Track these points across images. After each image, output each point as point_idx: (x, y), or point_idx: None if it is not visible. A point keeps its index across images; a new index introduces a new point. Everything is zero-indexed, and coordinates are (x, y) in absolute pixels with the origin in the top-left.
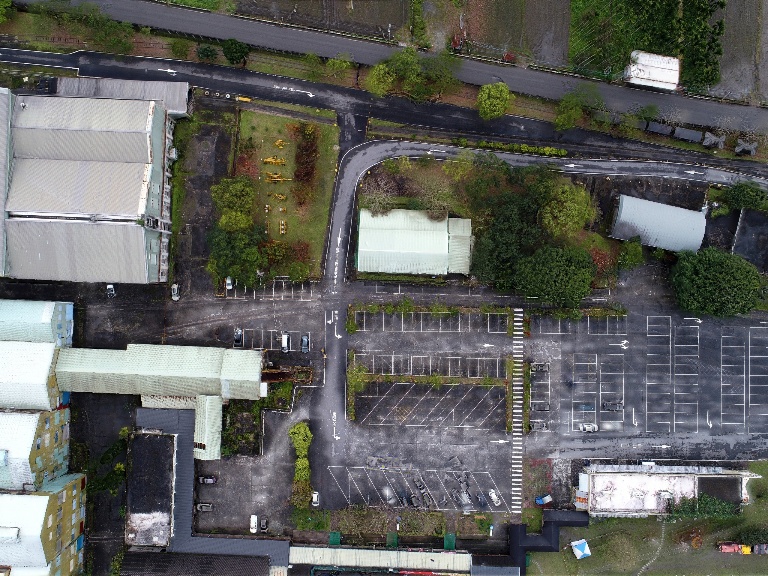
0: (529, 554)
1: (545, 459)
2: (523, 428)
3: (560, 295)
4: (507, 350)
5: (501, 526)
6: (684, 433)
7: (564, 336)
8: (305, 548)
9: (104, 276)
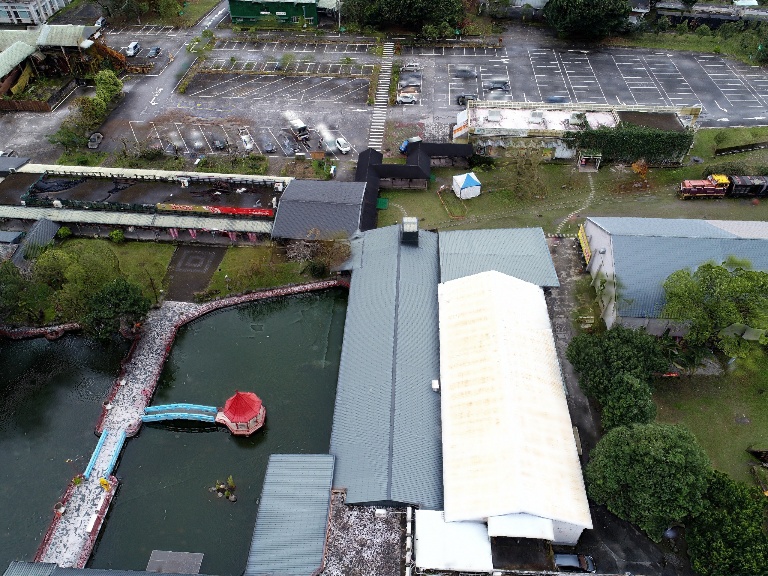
0: (388, 198)
1: (415, 123)
2: (388, 102)
3: (425, 3)
4: (375, 61)
5: (349, 172)
6: None
7: (438, 56)
8: (49, 165)
9: None
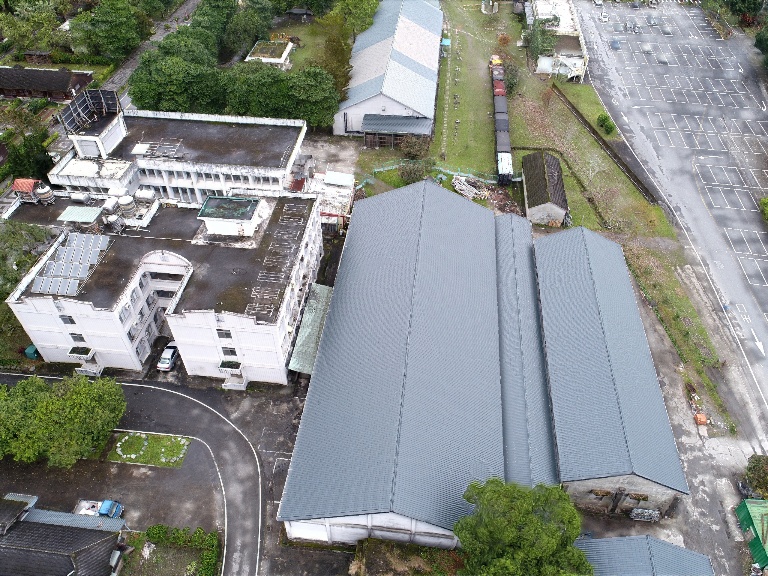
0: None
1: None
2: None
3: None
4: None
5: None
6: (613, 56)
7: (687, 16)
8: None
9: None
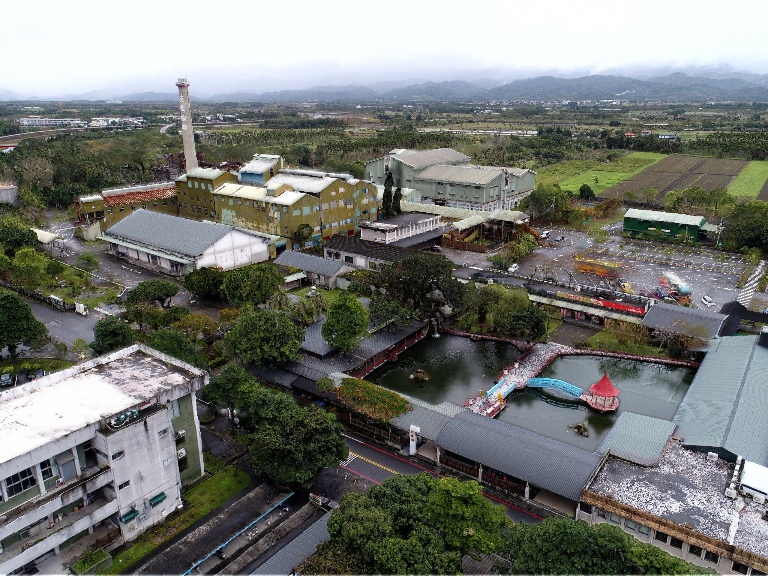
0: None
1: None
2: None
3: None
4: None
5: None
6: None
7: None
8: None
9: (463, 180)
